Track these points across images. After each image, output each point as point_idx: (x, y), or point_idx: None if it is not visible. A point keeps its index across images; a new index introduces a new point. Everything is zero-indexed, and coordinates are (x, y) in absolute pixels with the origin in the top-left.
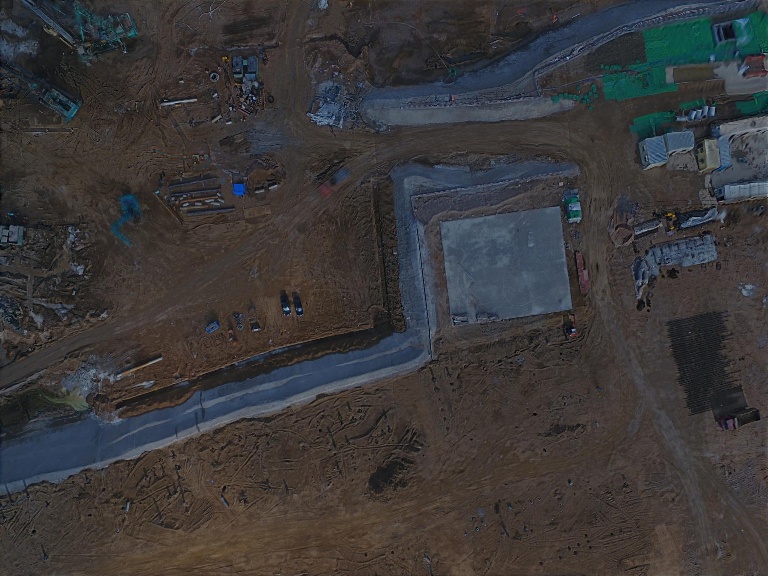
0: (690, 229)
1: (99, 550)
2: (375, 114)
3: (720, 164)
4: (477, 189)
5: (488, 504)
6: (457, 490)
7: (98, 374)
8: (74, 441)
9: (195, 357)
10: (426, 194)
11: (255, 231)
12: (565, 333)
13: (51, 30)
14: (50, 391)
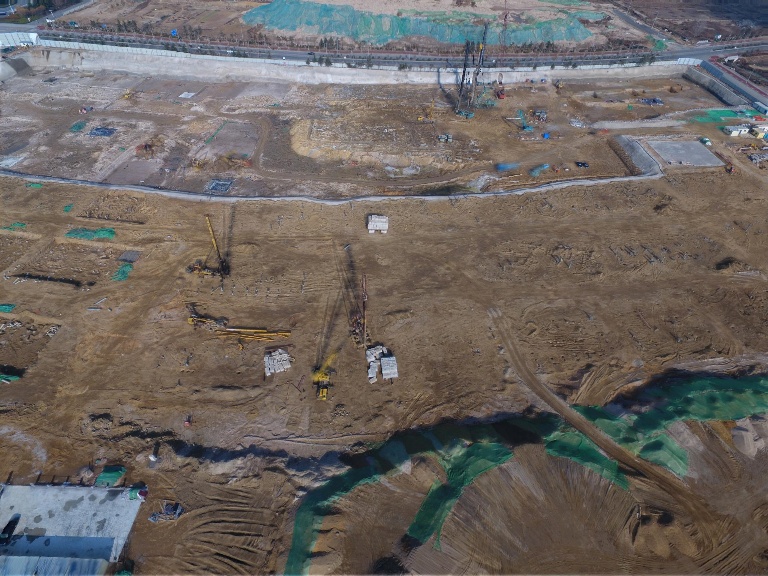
0: (766, 150)
1: (508, 221)
2: (598, 126)
3: (765, 133)
4: (657, 138)
5: (729, 221)
6: None
7: (490, 177)
8: None
9: None
10: (634, 137)
11: (556, 147)
12: (729, 172)
13: None
14: (461, 186)
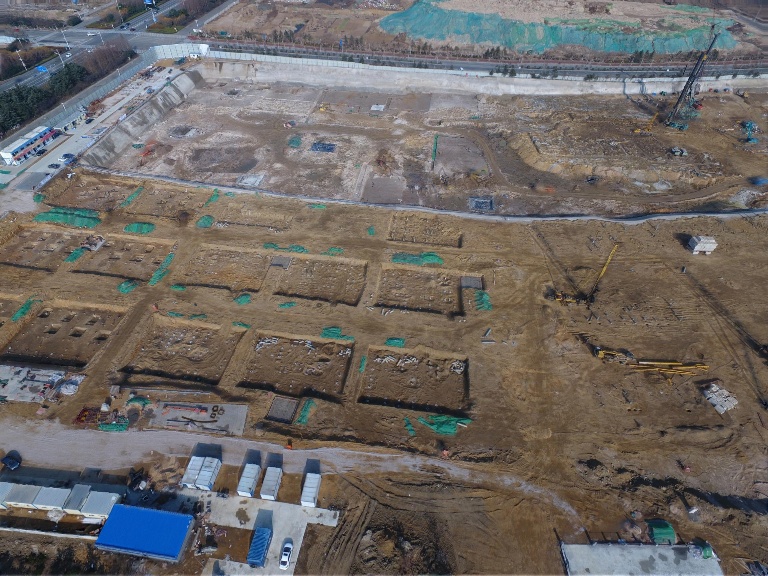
0: None
1: None
2: None
3: None
4: None
5: None
6: None
7: (752, 192)
8: (760, 210)
9: None
10: None
11: None
12: None
13: None
14: (723, 202)
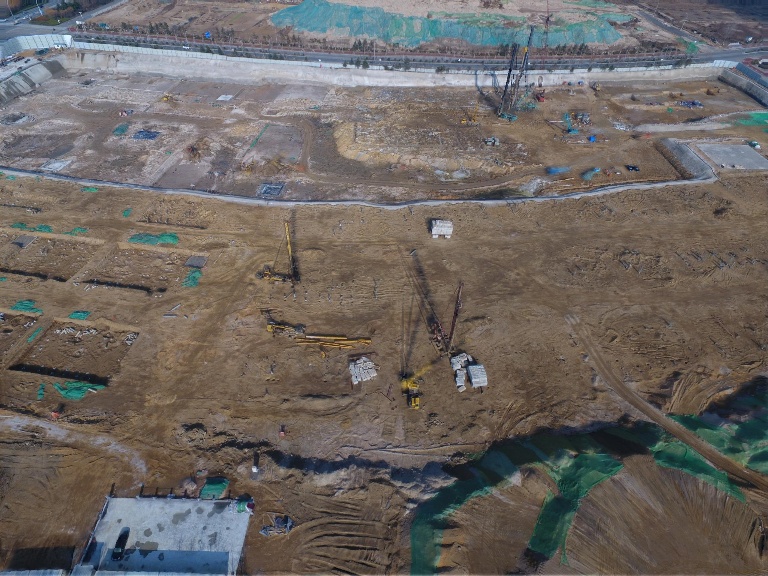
0: None
1: (570, 226)
2: (642, 129)
3: None
4: (704, 141)
5: None
6: (767, 220)
7: (542, 181)
8: None
9: (590, 179)
10: None
11: (603, 150)
12: None
13: (513, 96)
14: (513, 190)
